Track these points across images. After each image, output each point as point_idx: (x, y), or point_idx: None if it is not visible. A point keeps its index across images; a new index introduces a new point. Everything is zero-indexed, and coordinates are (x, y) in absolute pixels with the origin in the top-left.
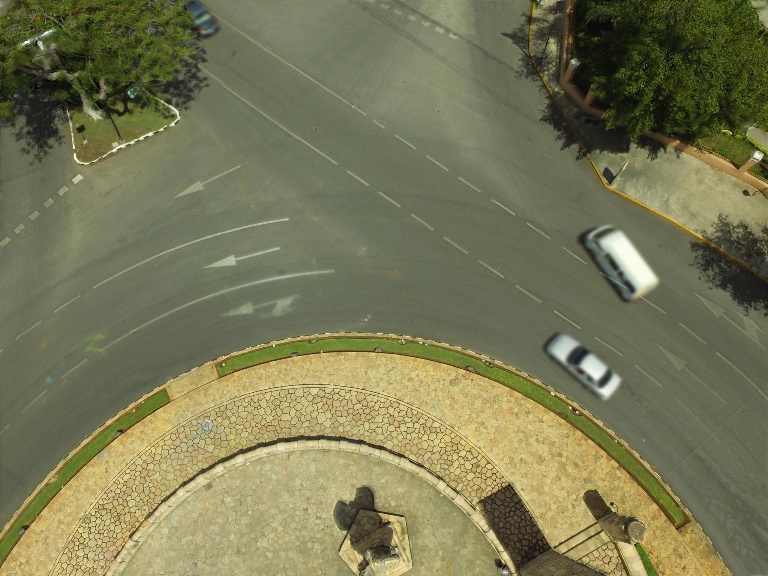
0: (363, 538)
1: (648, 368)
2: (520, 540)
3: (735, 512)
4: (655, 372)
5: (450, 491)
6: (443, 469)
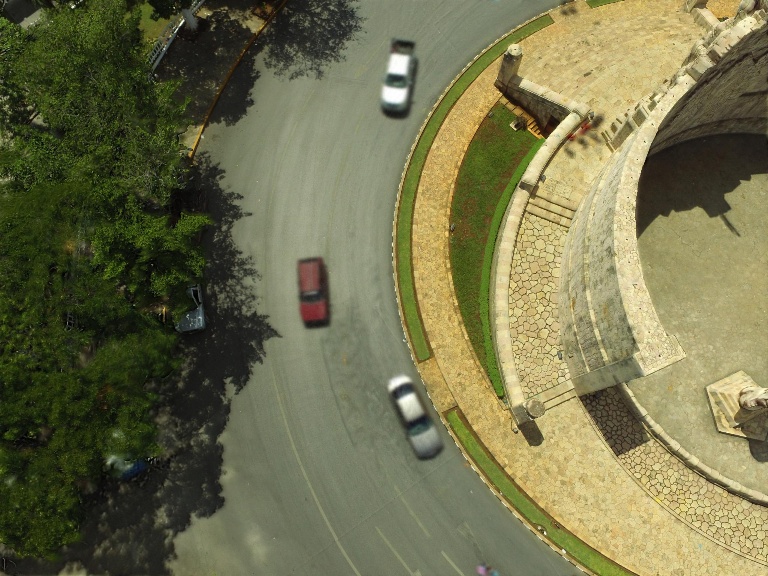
0: (760, 415)
1: (453, 575)
2: (608, 405)
3: (398, 418)
4: (446, 570)
5: (686, 454)
6: (686, 476)
